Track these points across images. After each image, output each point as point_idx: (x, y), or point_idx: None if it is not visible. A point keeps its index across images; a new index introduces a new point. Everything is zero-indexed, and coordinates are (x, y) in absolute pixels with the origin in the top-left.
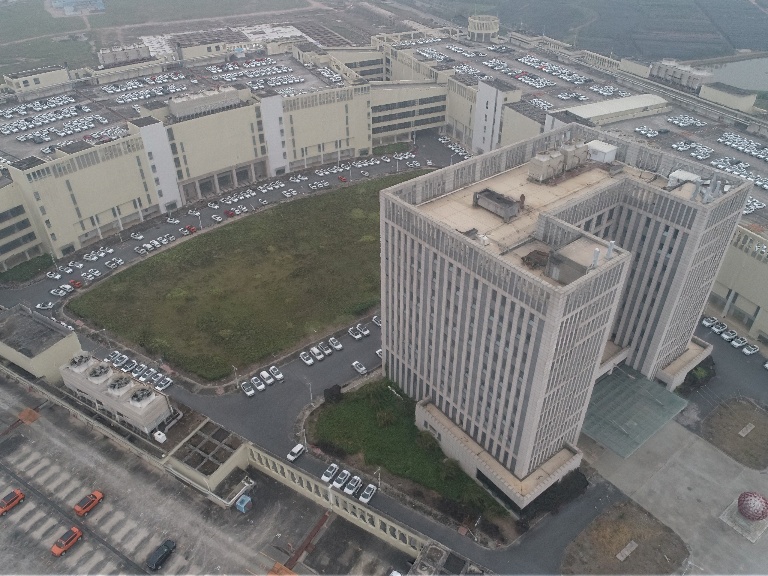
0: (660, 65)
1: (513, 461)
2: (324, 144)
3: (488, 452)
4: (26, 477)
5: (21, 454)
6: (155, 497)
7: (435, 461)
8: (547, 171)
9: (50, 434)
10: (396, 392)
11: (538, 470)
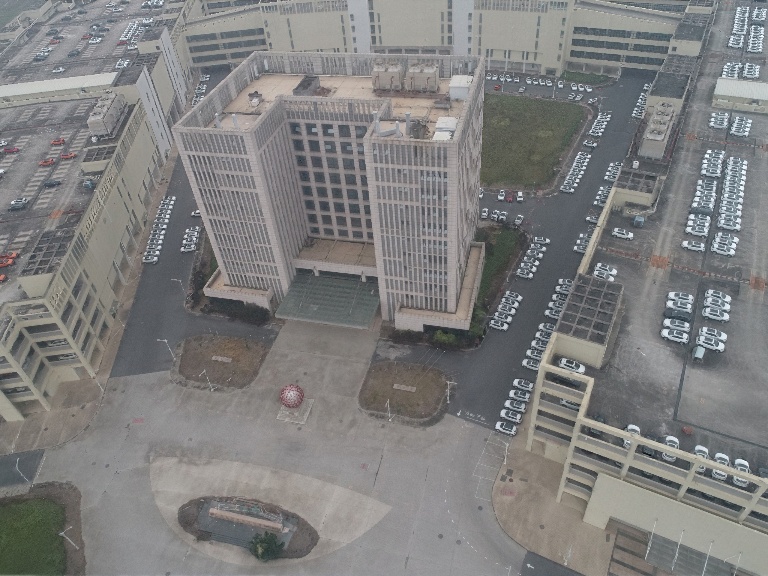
0: None
1: None
2: (511, 51)
3: None
4: (75, 138)
5: (86, 130)
6: None
7: None
8: (379, 82)
9: None
10: None
11: (239, 288)
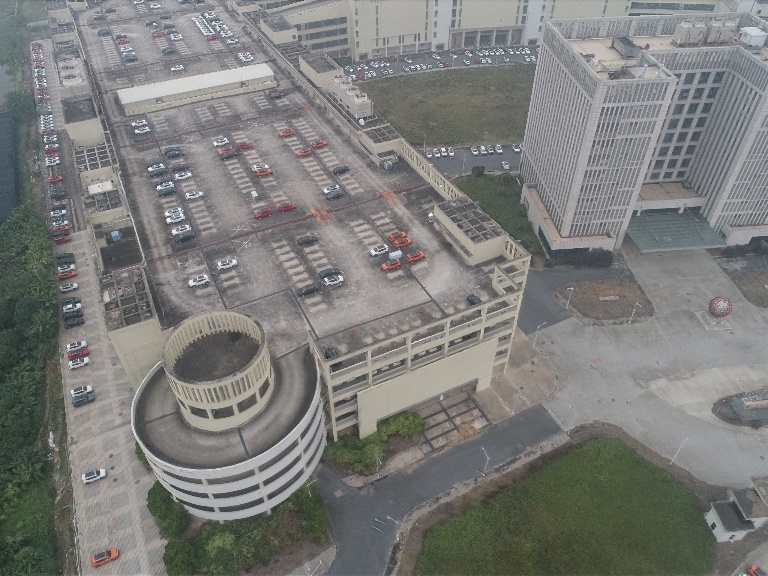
0: None
1: (561, 223)
2: None
3: (552, 219)
4: (297, 129)
5: (298, 120)
6: (349, 153)
7: (519, 220)
8: (686, 37)
9: (314, 117)
10: (520, 182)
11: (578, 238)
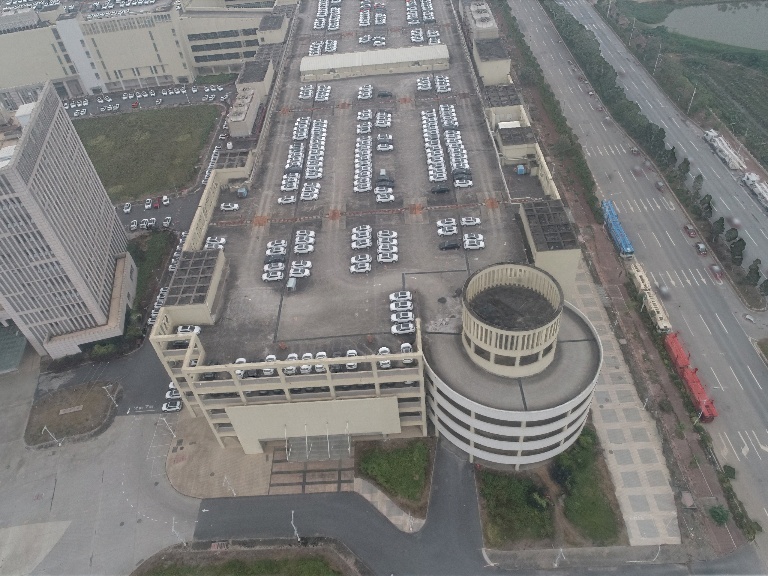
0: (466, 10)
1: None
2: (138, 68)
3: None
4: None
5: None
6: None
7: None
8: None
9: None
10: None
11: None
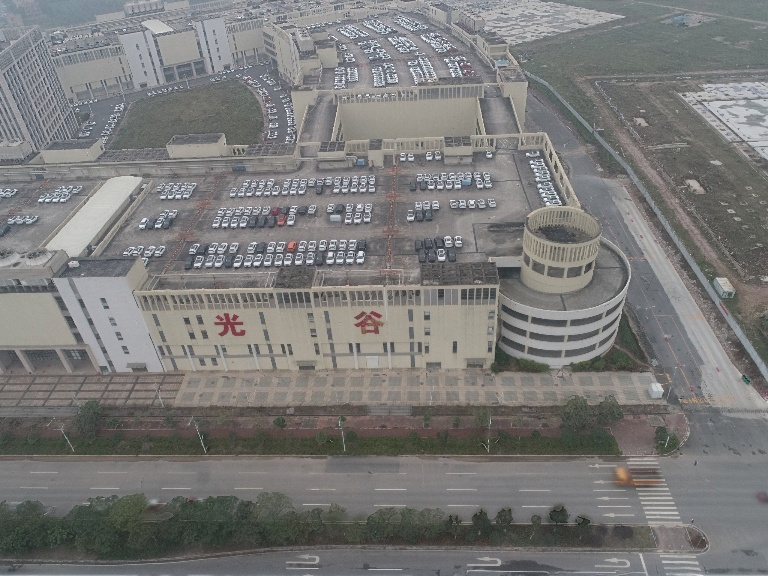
0: None
1: None
2: None
3: None
4: None
5: None
6: None
7: None
8: None
9: None
10: None
11: None
